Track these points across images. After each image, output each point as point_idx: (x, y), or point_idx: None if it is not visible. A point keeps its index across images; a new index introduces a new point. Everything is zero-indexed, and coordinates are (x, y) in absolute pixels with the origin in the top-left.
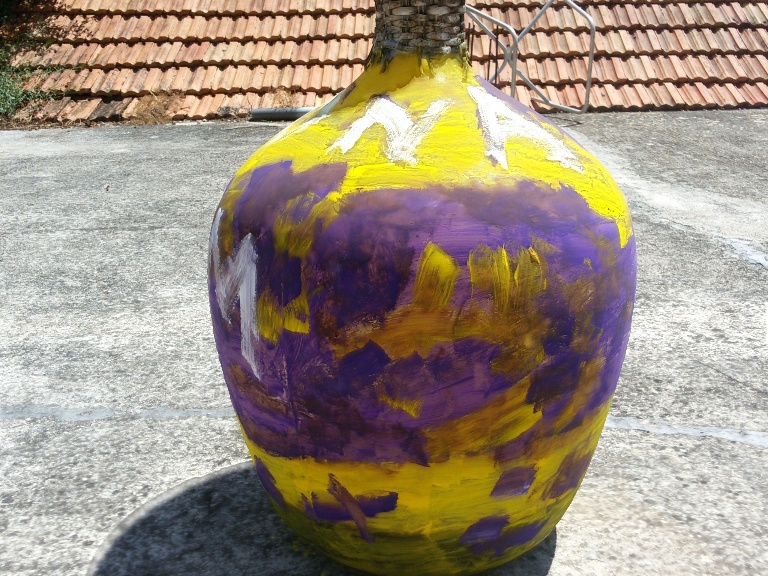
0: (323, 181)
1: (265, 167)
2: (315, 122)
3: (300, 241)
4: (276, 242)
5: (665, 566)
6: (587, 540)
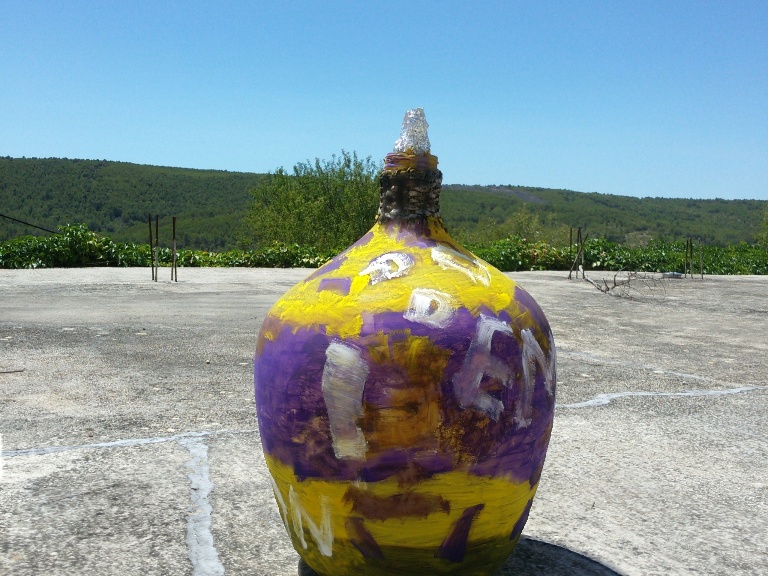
0: None
1: (517, 294)
2: (482, 265)
3: None
4: None
5: None
6: None
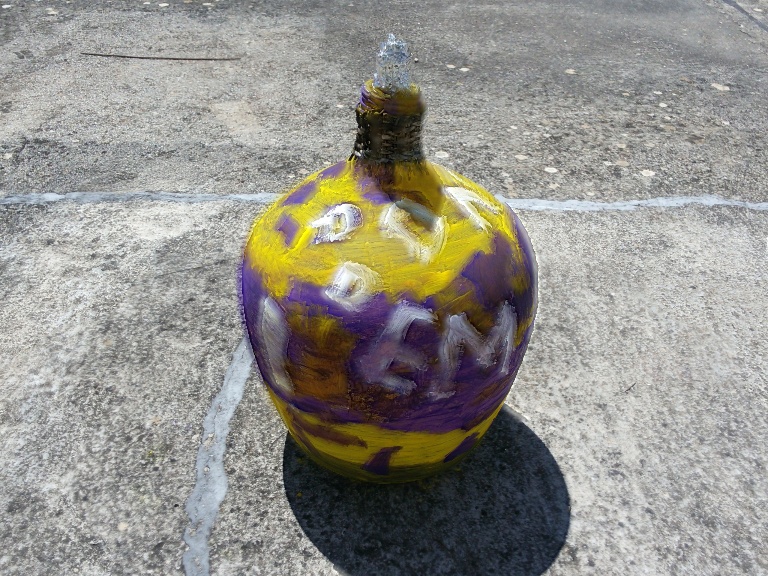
0: (509, 245)
1: (471, 266)
2: (446, 225)
3: (527, 279)
4: (520, 291)
5: None
6: None
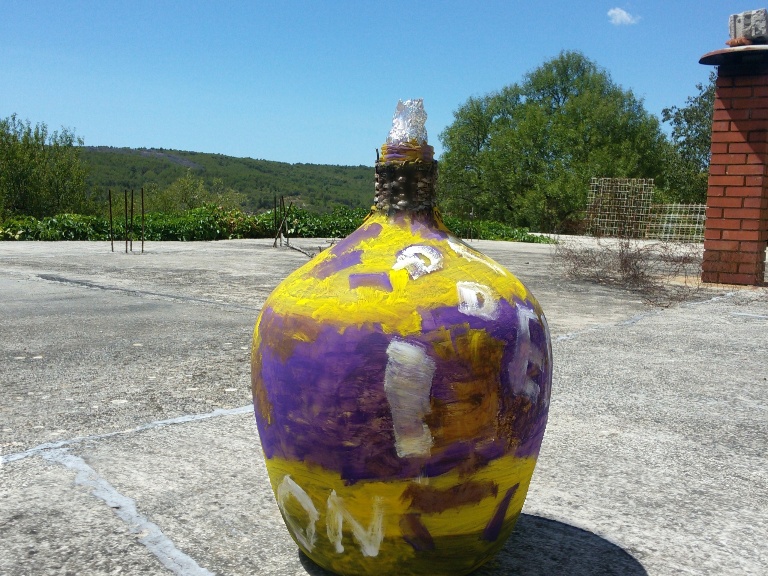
0: None
1: None
2: None
3: None
4: None
5: None
6: None
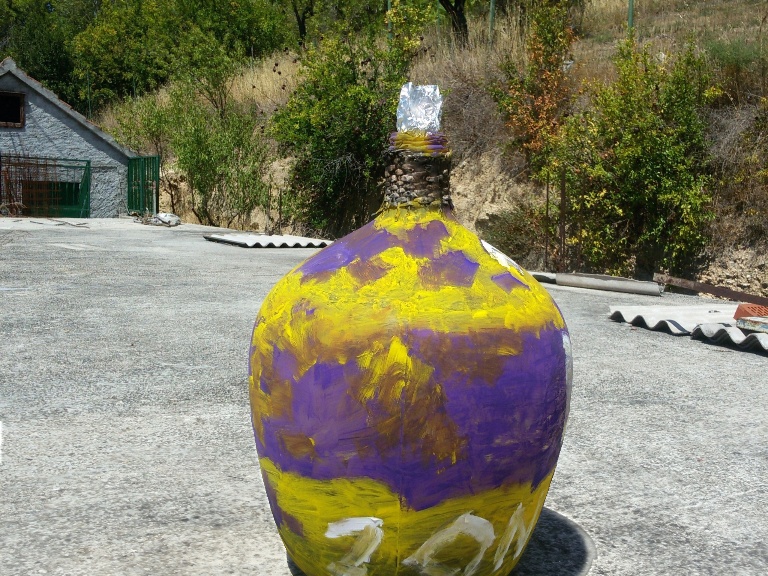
0: None
1: None
2: None
3: None
4: None
5: (207, 570)
6: (268, 574)
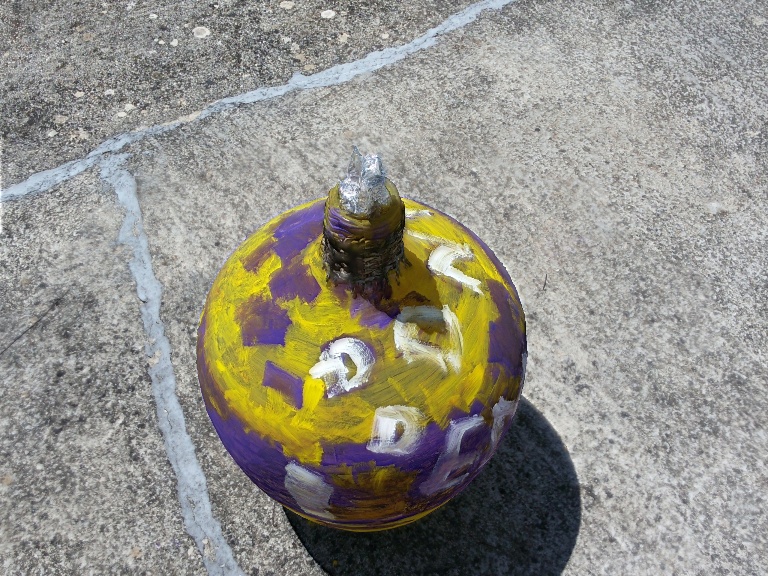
0: (502, 293)
1: (491, 347)
2: (452, 315)
3: None
4: None
5: None
6: None
